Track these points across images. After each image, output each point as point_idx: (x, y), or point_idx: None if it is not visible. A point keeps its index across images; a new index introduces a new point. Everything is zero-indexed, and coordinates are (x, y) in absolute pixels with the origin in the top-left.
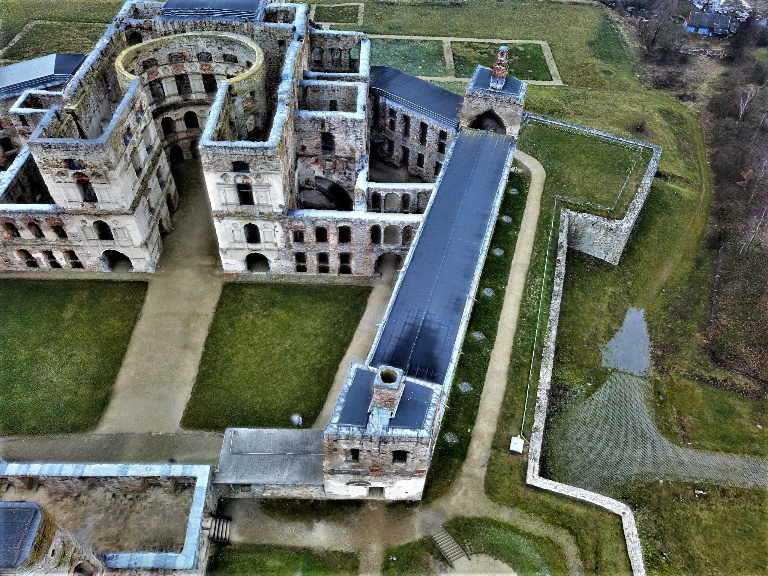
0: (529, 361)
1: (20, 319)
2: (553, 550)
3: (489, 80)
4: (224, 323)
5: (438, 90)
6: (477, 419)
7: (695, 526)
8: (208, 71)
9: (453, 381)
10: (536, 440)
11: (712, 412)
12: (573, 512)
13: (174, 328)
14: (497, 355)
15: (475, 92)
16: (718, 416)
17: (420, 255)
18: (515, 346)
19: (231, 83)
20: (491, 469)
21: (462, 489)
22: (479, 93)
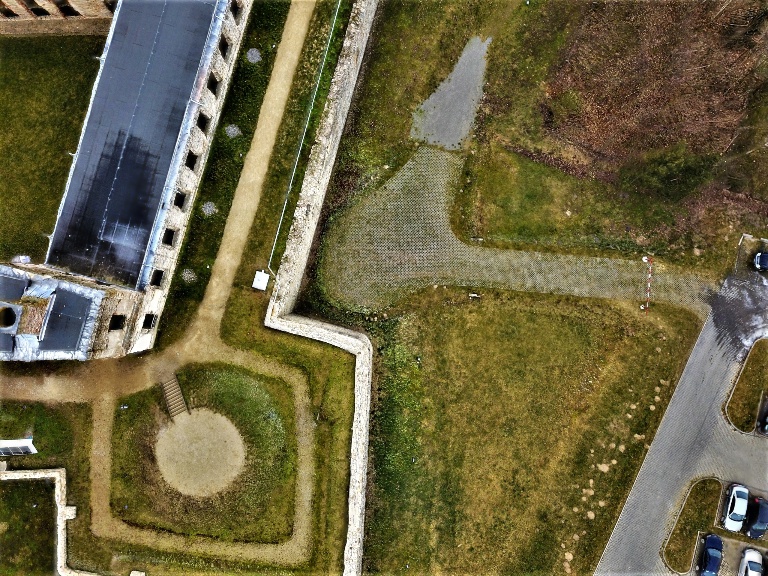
0: (291, 167)
1: None
2: (283, 390)
3: None
4: None
5: None
6: (219, 251)
7: (458, 330)
8: None
9: (194, 202)
10: (284, 273)
11: (521, 198)
12: (309, 353)
13: None
14: (253, 160)
15: None
16: (526, 203)
17: (124, 31)
18: (277, 145)
19: None
20: (229, 311)
21: (196, 334)
22: None
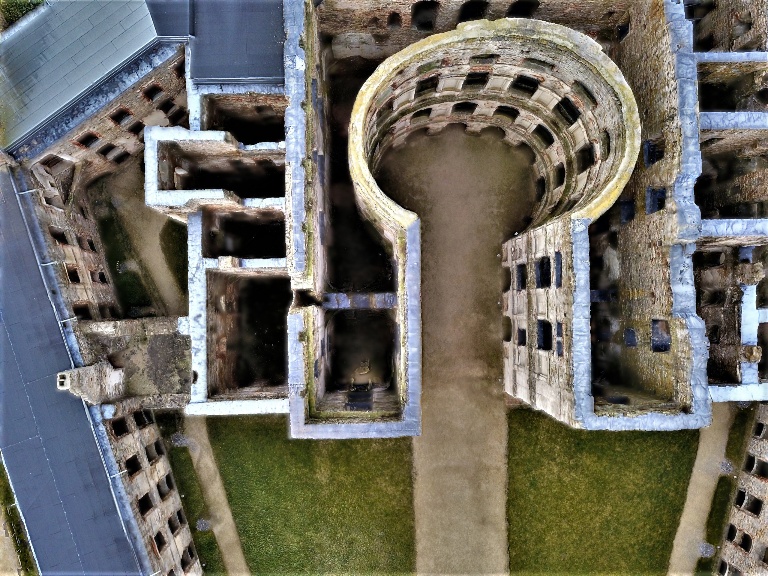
0: None
1: (268, 486)
2: None
3: None
4: (523, 482)
5: None
6: None
7: None
8: (480, 70)
9: None
10: None
11: None
12: None
13: (463, 492)
14: None
15: None
16: None
17: None
18: None
19: (591, 221)
20: None
21: None
22: None
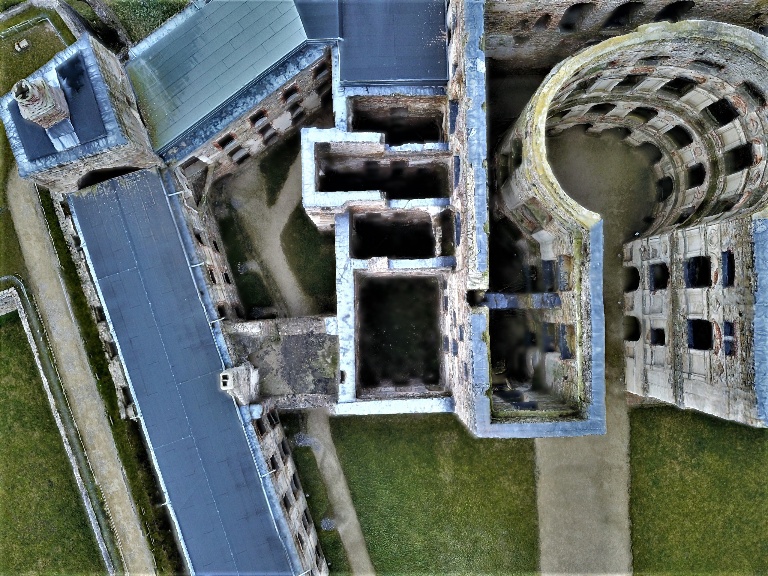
0: None
1: (392, 486)
2: None
3: None
4: (646, 481)
5: None
6: None
7: None
8: (639, 71)
9: None
10: None
11: None
12: None
13: (586, 491)
14: None
15: None
16: None
17: None
18: None
19: None
20: None
21: None
22: None
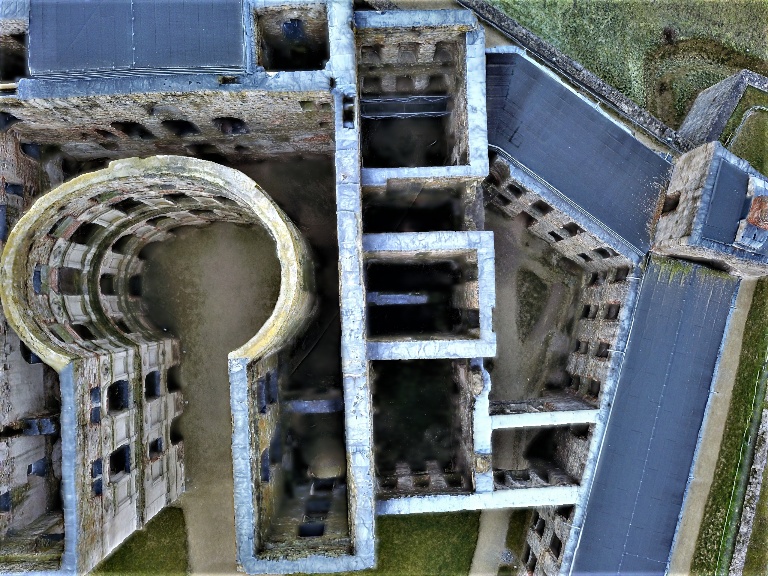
0: None
1: None
2: None
3: (736, 219)
4: None
5: (611, 137)
6: None
7: None
8: (173, 192)
9: None
10: None
11: None
12: None
13: None
14: None
15: (702, 246)
16: None
17: None
18: None
19: (249, 360)
20: None
21: None
22: (709, 249)
